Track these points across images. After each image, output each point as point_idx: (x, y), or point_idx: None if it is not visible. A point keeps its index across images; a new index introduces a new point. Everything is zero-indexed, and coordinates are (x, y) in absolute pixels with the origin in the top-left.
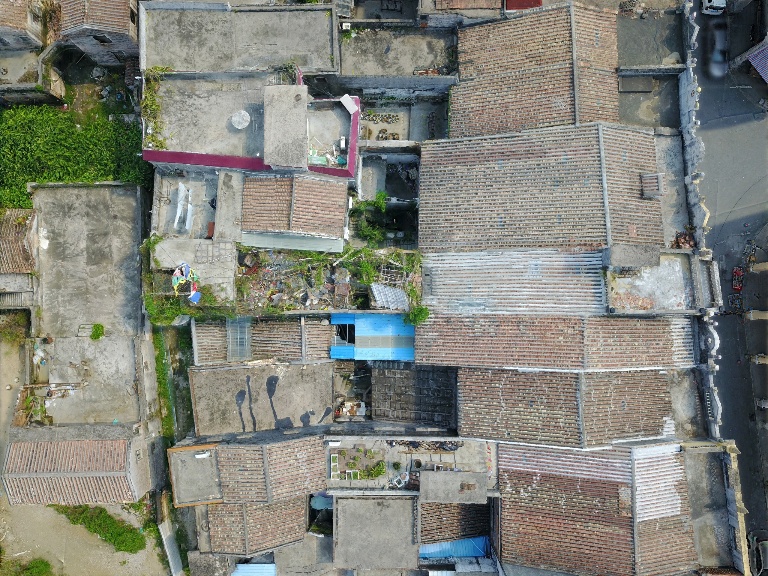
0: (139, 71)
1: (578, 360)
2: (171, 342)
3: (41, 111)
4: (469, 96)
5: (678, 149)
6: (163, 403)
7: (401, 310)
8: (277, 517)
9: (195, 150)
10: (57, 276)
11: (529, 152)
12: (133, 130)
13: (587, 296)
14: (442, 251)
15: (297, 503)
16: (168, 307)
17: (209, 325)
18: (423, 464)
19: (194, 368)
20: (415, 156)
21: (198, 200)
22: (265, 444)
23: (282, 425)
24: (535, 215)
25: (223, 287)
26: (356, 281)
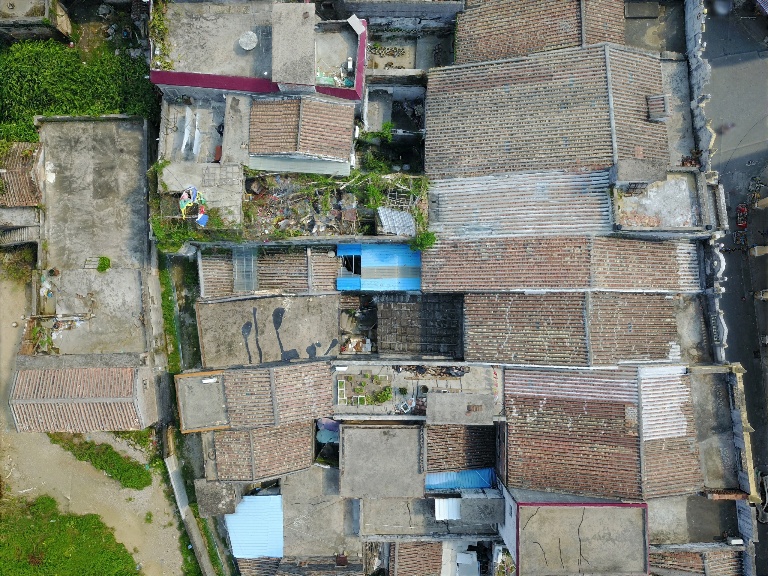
0: (145, 6)
1: (585, 279)
2: (177, 279)
3: (48, 45)
4: (475, 23)
5: (684, 74)
6: (169, 340)
7: (408, 236)
8: (284, 445)
9: (203, 72)
10: (64, 210)
11: (536, 75)
12: (139, 64)
13: (594, 215)
14: (448, 177)
15: (303, 431)
16: (175, 231)
17: (215, 258)
18: (429, 390)
19: (200, 300)
20: (421, 90)
21: (205, 127)
22: (272, 367)
23: (288, 357)
24: (542, 138)
25: (230, 210)
26: (363, 207)
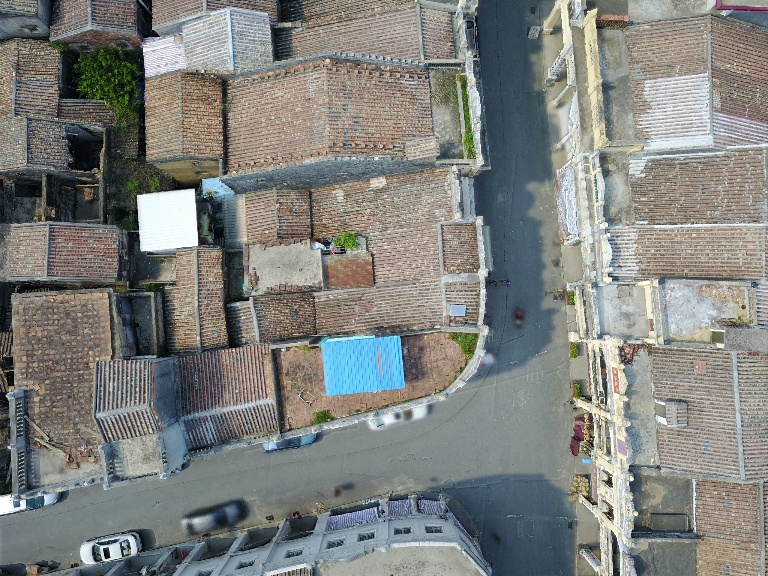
0: None
1: None
2: None
3: None
4: None
5: None
6: None
7: None
8: None
9: None
10: None
11: None
12: None
13: (764, 301)
14: None
15: None
16: None
17: None
18: None
19: None
20: None
21: None
22: None
23: None
24: None
25: None
26: None
